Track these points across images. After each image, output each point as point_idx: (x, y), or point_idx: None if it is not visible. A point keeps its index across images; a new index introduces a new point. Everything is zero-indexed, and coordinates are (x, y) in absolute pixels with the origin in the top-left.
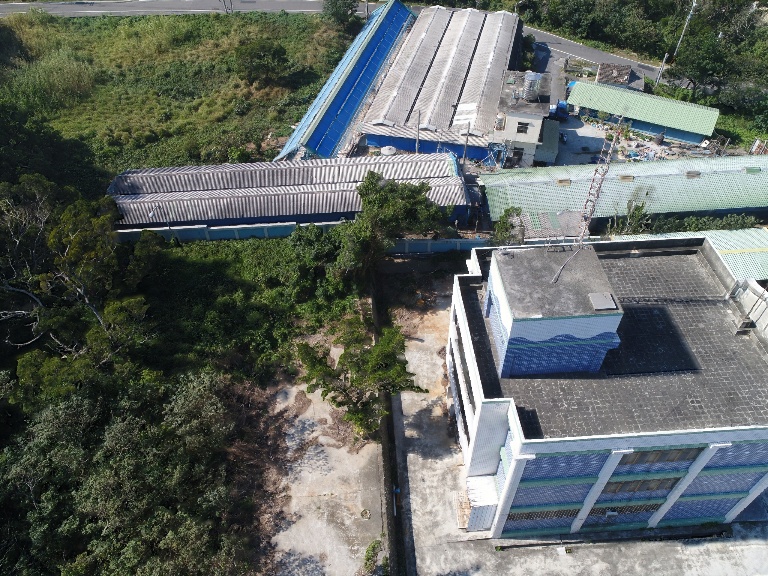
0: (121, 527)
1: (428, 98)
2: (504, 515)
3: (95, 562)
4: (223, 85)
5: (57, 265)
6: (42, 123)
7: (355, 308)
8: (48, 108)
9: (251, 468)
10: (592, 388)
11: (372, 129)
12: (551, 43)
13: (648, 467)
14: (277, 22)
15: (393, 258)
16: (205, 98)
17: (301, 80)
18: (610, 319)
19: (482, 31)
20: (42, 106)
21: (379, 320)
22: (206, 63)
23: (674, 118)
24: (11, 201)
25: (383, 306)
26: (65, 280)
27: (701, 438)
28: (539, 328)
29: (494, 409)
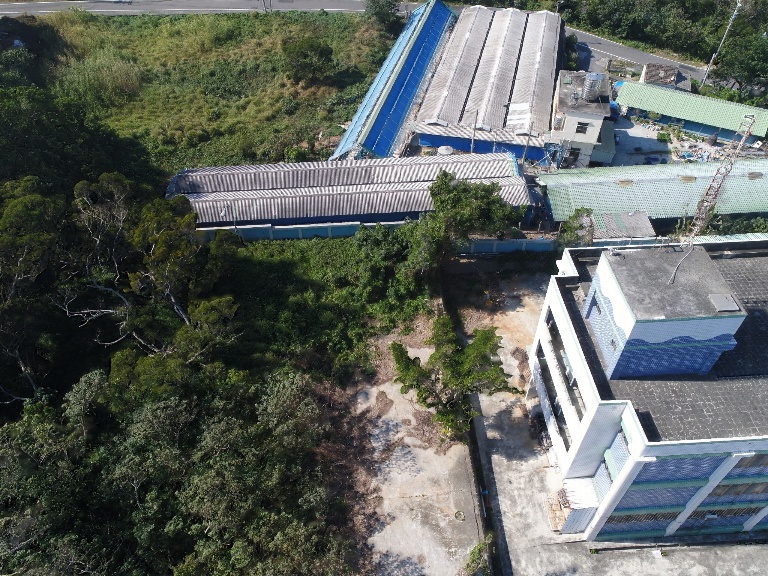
0: (226, 528)
1: (479, 98)
2: (605, 518)
3: (203, 563)
4: (269, 84)
5: (146, 264)
6: None
7: (430, 308)
8: (99, 107)
9: (340, 469)
10: (704, 390)
11: (426, 129)
12: (591, 43)
13: (760, 470)
14: (317, 21)
15: (458, 258)
16: (252, 97)
17: (347, 79)
18: (732, 321)
19: (526, 31)
20: (93, 104)
21: None
22: (250, 62)
23: (726, 119)
24: (90, 199)
25: (452, 306)
26: (150, 279)
27: None
28: (660, 329)
29: (609, 411)
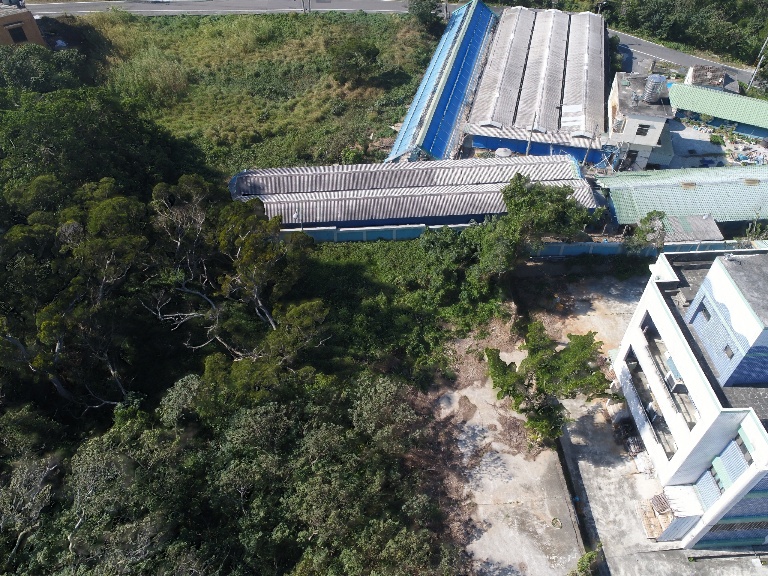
0: (334, 535)
1: (531, 99)
2: (710, 526)
3: (313, 571)
4: (315, 85)
5: (236, 267)
6: None
7: None
8: (149, 107)
9: (431, 475)
10: None
11: (480, 130)
12: (632, 44)
13: None
14: (357, 22)
15: (525, 261)
16: (299, 98)
17: (392, 80)
18: None
19: (570, 32)
20: None
21: None
22: (295, 63)
23: None
24: None
25: (522, 310)
26: (236, 282)
27: None
28: None
29: (729, 419)
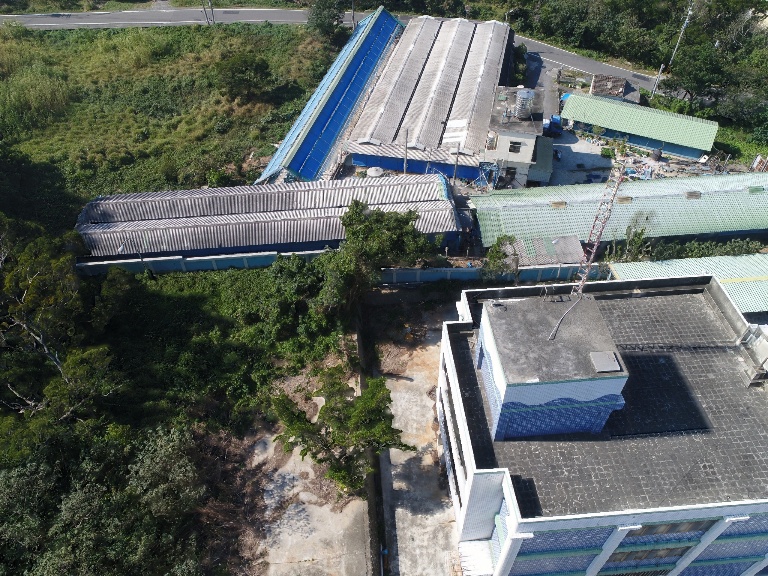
0: None
1: (416, 114)
2: None
3: None
4: (204, 101)
5: (12, 314)
6: (12, 145)
7: (339, 347)
8: (18, 129)
9: (226, 531)
10: (594, 452)
11: (358, 148)
12: (543, 53)
13: (657, 538)
14: (260, 34)
15: (380, 289)
16: (184, 115)
17: (285, 95)
18: (614, 382)
19: (472, 42)
20: (12, 127)
21: (365, 357)
22: (186, 78)
23: (672, 132)
24: None
25: (370, 341)
26: (23, 327)
27: (716, 512)
28: (536, 392)
29: (487, 479)
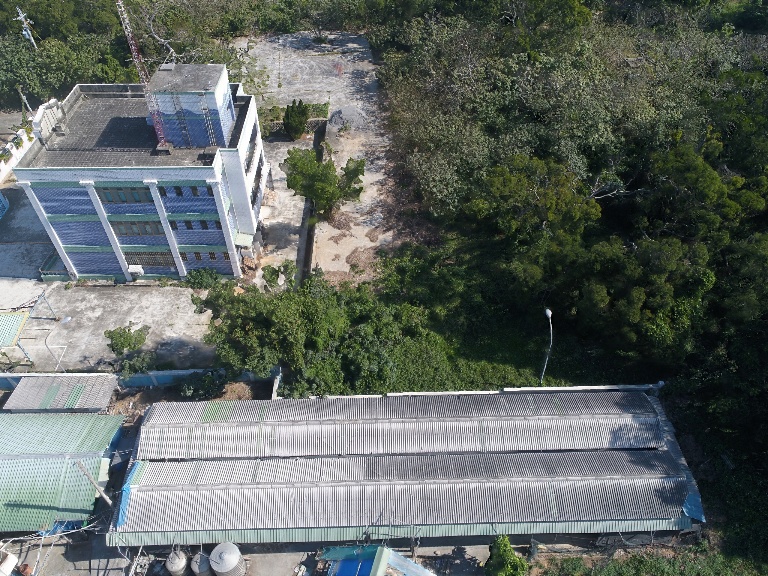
0: None
1: None
2: None
3: None
4: None
5: None
6: None
7: None
8: None
9: None
10: None
11: None
12: None
13: None
14: None
15: None
16: None
17: None
18: None
19: None
20: None
21: None
22: None
23: None
24: None
25: None
26: None
27: None
28: None
29: None
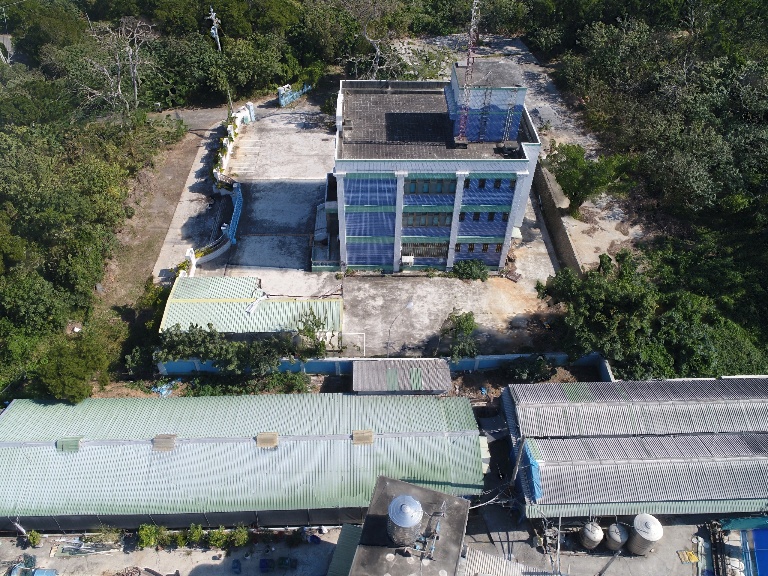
0: None
1: None
2: None
3: None
4: None
5: None
6: None
7: None
8: None
9: None
10: None
11: None
12: None
13: None
14: None
15: None
16: None
17: None
18: None
19: None
20: None
21: None
22: None
23: None
24: None
25: None
26: None
27: None
28: None
29: None
